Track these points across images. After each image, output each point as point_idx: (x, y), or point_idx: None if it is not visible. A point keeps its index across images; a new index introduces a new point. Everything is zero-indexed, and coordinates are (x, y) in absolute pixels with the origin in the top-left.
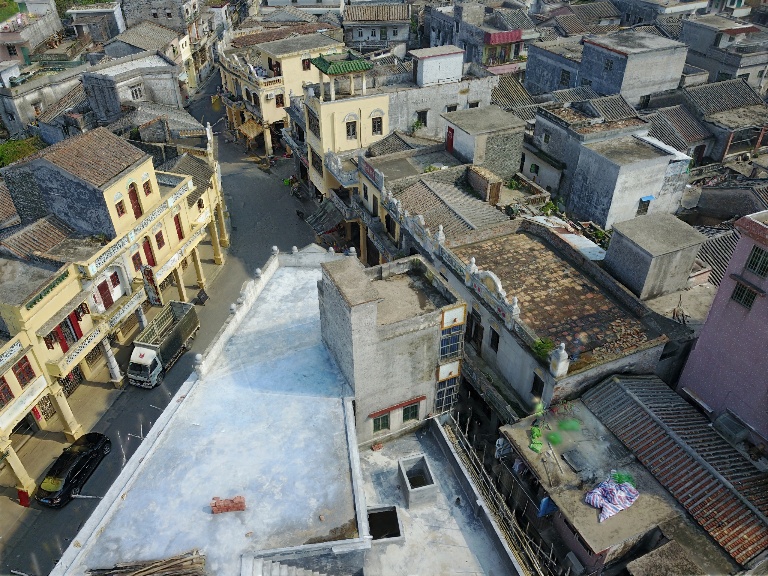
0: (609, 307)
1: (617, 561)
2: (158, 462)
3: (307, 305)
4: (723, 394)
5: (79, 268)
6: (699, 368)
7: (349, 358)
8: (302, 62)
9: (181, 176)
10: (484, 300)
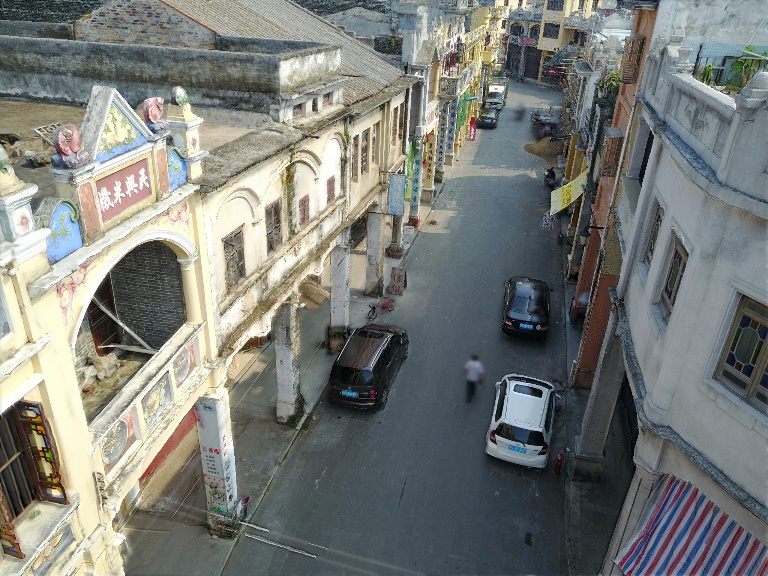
0: None
1: None
2: None
3: None
4: None
5: (492, 13)
6: None
7: None
8: (504, 0)
9: None
10: None
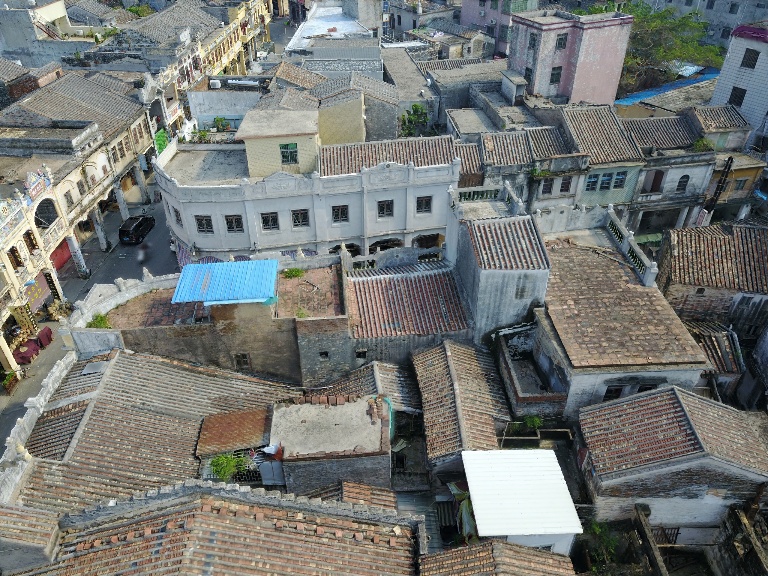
0: (436, 4)
1: (440, 52)
2: None
3: None
4: (470, 19)
5: (245, 5)
6: (464, 15)
7: (356, 5)
8: None
9: None
10: (394, 6)
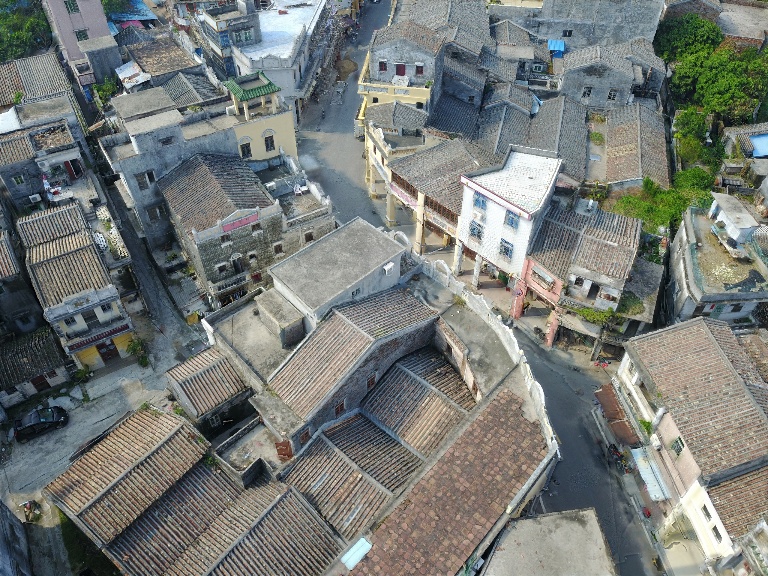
0: None
1: None
2: (308, 18)
3: (271, 53)
4: None
5: None
6: None
7: None
8: None
9: (365, 83)
10: None
